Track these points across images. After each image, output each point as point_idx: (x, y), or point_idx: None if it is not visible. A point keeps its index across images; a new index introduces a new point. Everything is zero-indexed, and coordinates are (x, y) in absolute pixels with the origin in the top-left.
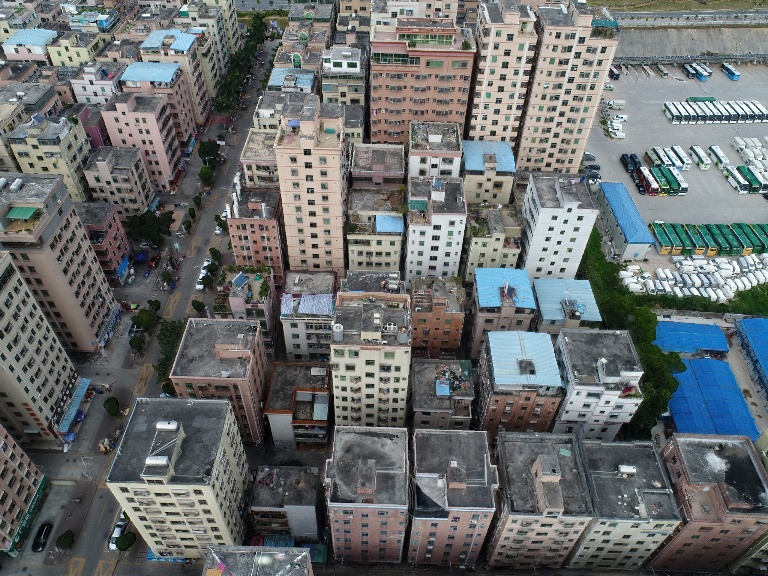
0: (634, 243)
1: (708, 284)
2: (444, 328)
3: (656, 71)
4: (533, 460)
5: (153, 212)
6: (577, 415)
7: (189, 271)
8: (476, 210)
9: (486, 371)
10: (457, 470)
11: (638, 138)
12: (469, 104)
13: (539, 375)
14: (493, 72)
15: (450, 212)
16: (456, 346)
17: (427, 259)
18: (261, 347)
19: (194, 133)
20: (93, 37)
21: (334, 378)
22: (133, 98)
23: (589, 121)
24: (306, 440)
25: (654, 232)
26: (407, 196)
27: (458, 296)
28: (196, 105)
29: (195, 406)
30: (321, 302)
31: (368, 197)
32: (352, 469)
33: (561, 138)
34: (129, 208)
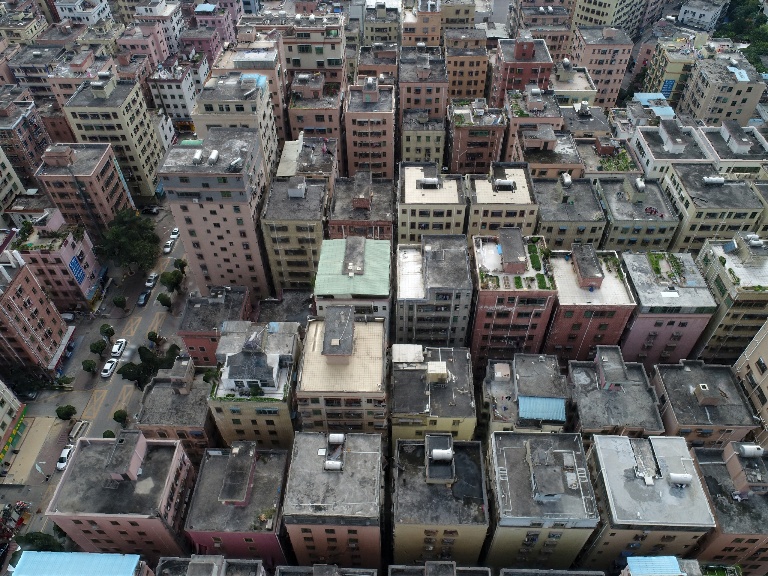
0: None
1: None
2: None
3: None
4: None
5: None
6: None
7: None
8: None
9: None
10: None
11: None
12: None
13: None
14: None
15: None
16: None
17: None
18: None
19: None
20: None
21: None
22: None
23: None
24: None
25: None
26: None
27: None
28: None
29: None
30: None
31: None
32: (13, 116)
33: None
34: None
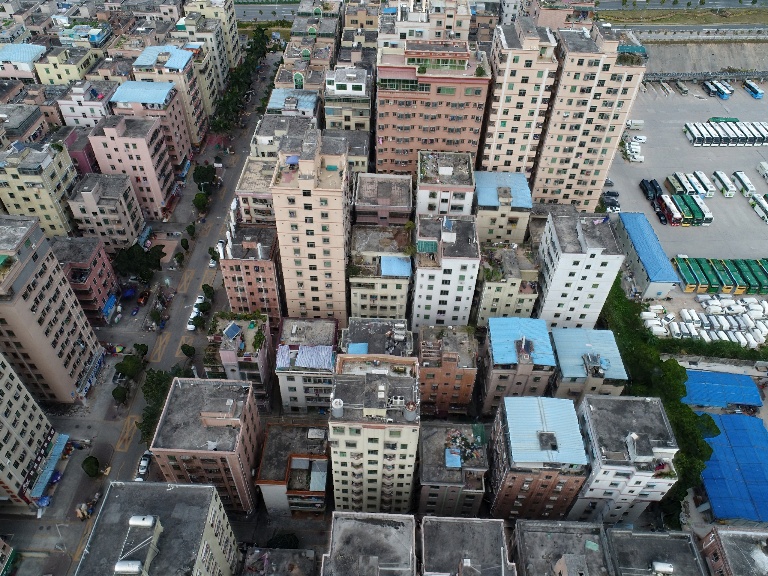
0: (657, 281)
1: (737, 327)
2: (454, 383)
3: (675, 88)
4: (556, 555)
5: (143, 243)
6: (603, 493)
7: (180, 309)
8: (490, 251)
9: (502, 442)
10: (471, 570)
11: (658, 161)
12: (482, 132)
13: (562, 451)
14: (509, 100)
15: (462, 255)
16: (467, 401)
17: (436, 303)
18: (253, 409)
19: (189, 155)
20: (84, 53)
21: (333, 454)
22: (123, 122)
23: (611, 152)
24: (302, 509)
25: (678, 268)
26: (415, 235)
27: (470, 348)
28: (192, 125)
29: (175, 491)
30: (320, 354)
31: (373, 235)
32: (352, 565)
33: (580, 169)
34: (117, 240)
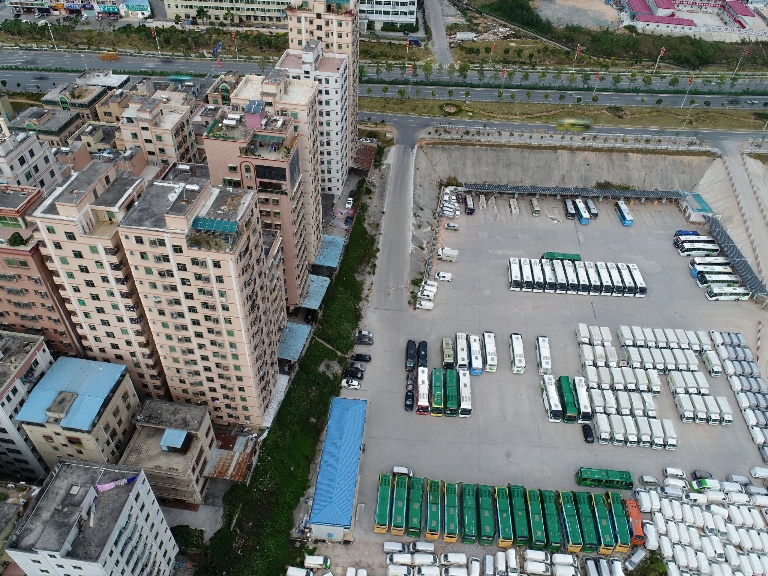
0: (318, 523)
1: None
2: None
3: (529, 205)
4: None
5: None
6: None
7: None
8: None
9: None
10: None
11: (452, 310)
12: None
13: None
14: (72, 275)
15: None
16: None
17: None
18: None
19: None
20: None
21: None
22: None
23: (243, 347)
24: None
25: (378, 492)
26: None
27: None
28: None
29: None
30: None
31: None
32: None
33: (214, 362)
34: None
